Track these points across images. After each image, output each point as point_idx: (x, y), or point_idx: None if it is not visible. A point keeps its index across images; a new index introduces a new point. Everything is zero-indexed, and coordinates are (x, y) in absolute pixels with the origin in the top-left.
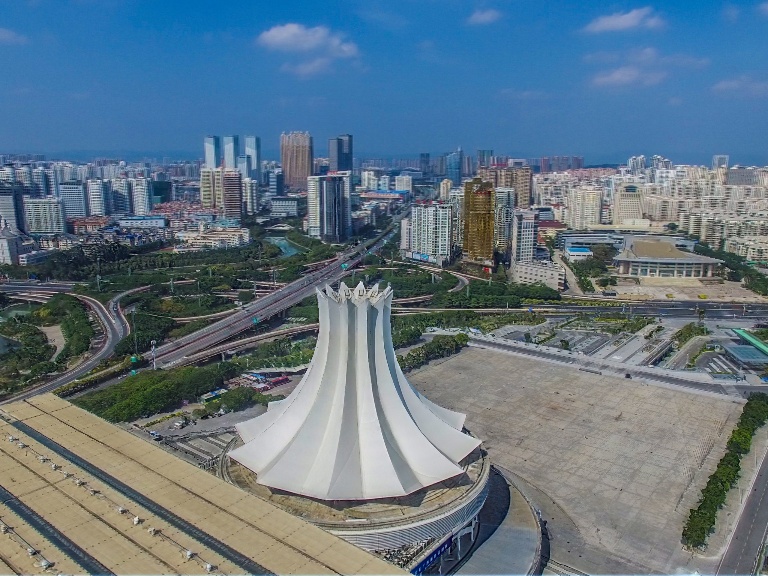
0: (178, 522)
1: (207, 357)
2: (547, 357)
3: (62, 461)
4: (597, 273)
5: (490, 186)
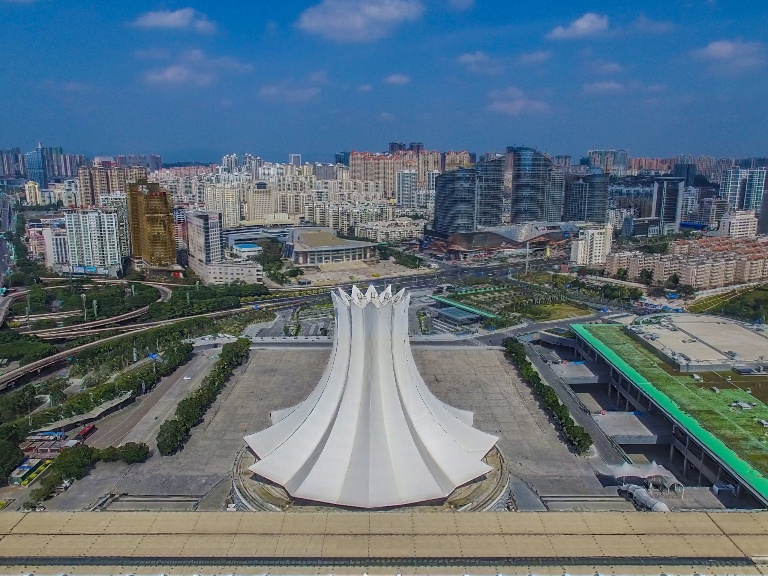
0: (399, 562)
1: None
2: (325, 345)
3: (154, 570)
4: (279, 266)
5: (158, 187)
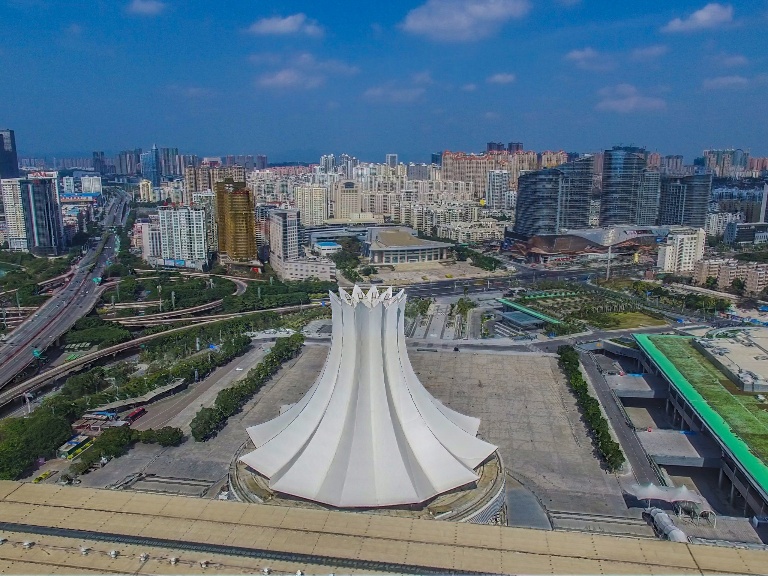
0: (339, 562)
1: (0, 406)
2: None
3: (111, 546)
4: (355, 264)
5: (243, 185)
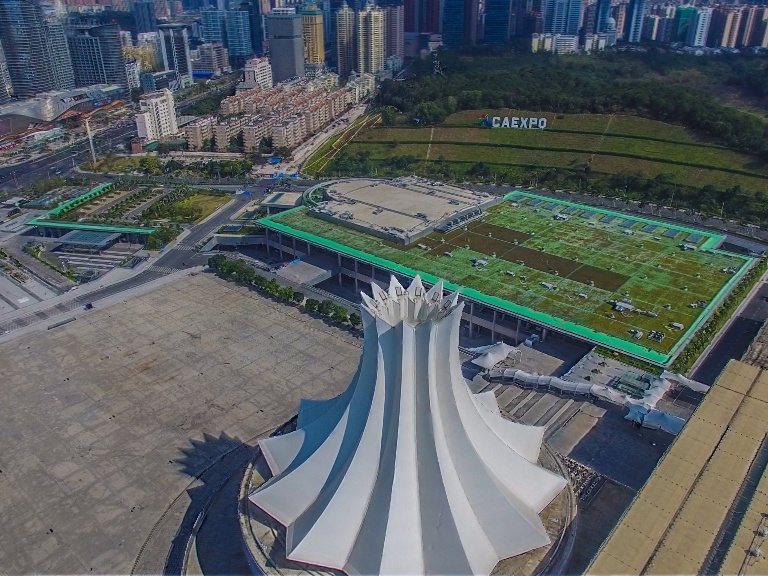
0: None
1: None
2: None
3: None
4: None
5: None
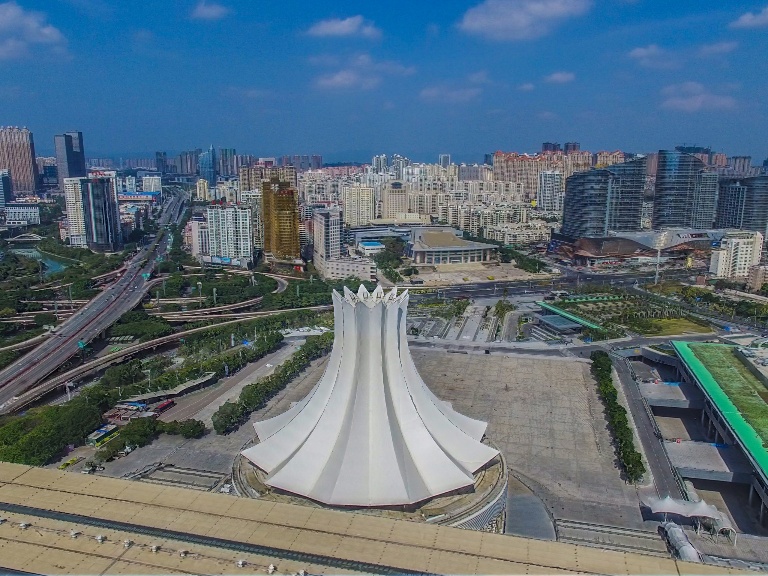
0: (314, 559)
1: (43, 394)
2: (409, 345)
3: (100, 531)
4: (397, 264)
5: (289, 185)
